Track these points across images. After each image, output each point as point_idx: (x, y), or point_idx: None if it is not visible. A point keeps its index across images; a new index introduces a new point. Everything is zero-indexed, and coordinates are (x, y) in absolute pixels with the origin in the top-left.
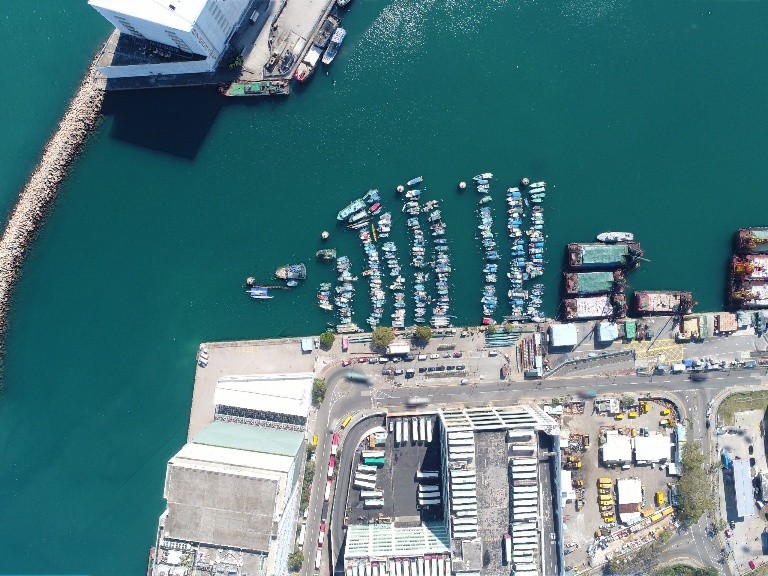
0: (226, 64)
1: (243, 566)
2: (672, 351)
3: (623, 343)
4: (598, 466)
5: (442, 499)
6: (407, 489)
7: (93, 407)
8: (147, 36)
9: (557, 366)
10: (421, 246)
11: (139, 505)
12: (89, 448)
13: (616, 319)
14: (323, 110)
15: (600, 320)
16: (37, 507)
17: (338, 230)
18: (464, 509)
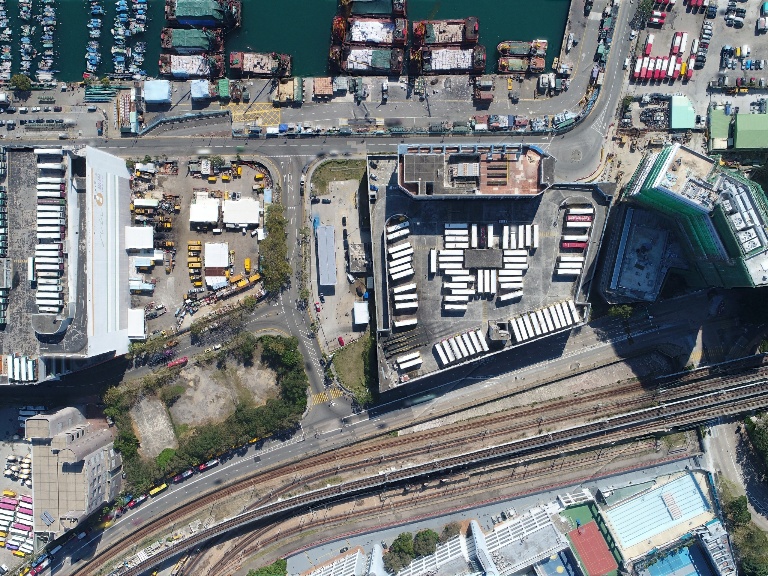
0: None
1: None
2: (269, 115)
3: (221, 105)
4: (190, 229)
5: None
6: None
7: None
8: None
9: (153, 124)
10: None
11: None
12: None
13: (215, 80)
14: None
15: None
16: None
17: None
18: None
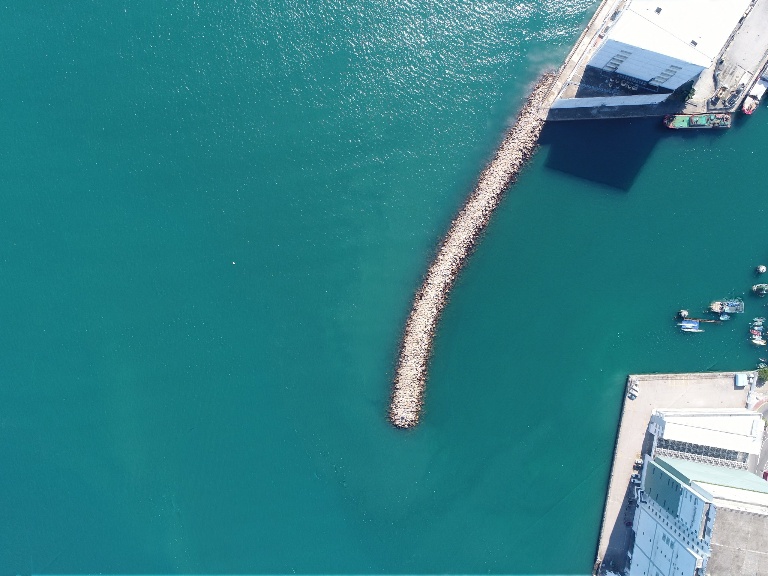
0: (680, 97)
1: None
2: None
3: None
4: None
5: None
6: None
7: (514, 436)
8: (622, 69)
9: None
10: None
11: (557, 537)
12: (510, 477)
13: None
14: (763, 144)
15: None
16: (454, 535)
17: None
18: None
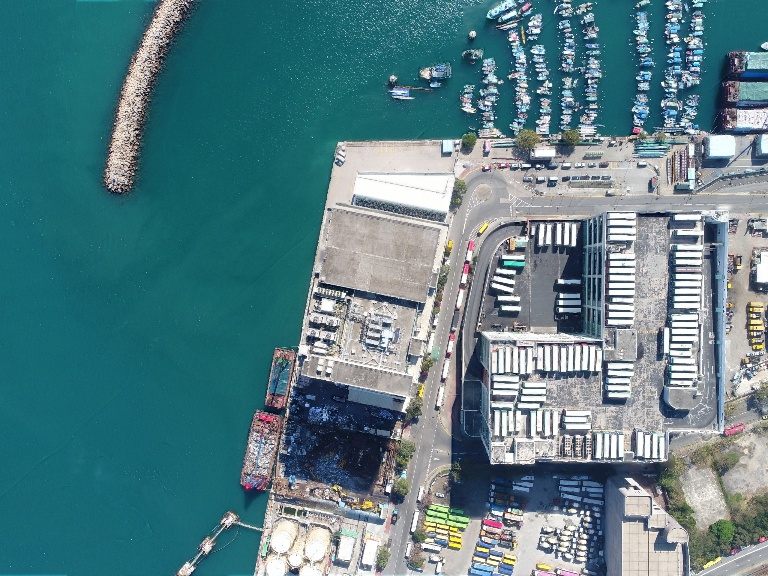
0: None
1: (397, 320)
2: None
3: None
4: (749, 290)
5: (583, 308)
6: (545, 298)
7: (226, 204)
8: None
9: (710, 180)
10: (571, 50)
11: (265, 306)
12: (220, 244)
13: None
14: None
15: (759, 134)
16: (165, 301)
17: (485, 32)
18: (620, 295)
